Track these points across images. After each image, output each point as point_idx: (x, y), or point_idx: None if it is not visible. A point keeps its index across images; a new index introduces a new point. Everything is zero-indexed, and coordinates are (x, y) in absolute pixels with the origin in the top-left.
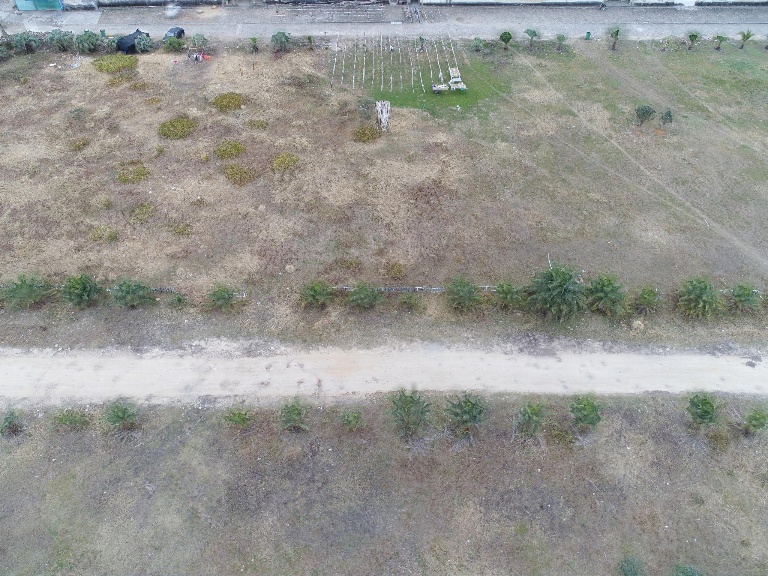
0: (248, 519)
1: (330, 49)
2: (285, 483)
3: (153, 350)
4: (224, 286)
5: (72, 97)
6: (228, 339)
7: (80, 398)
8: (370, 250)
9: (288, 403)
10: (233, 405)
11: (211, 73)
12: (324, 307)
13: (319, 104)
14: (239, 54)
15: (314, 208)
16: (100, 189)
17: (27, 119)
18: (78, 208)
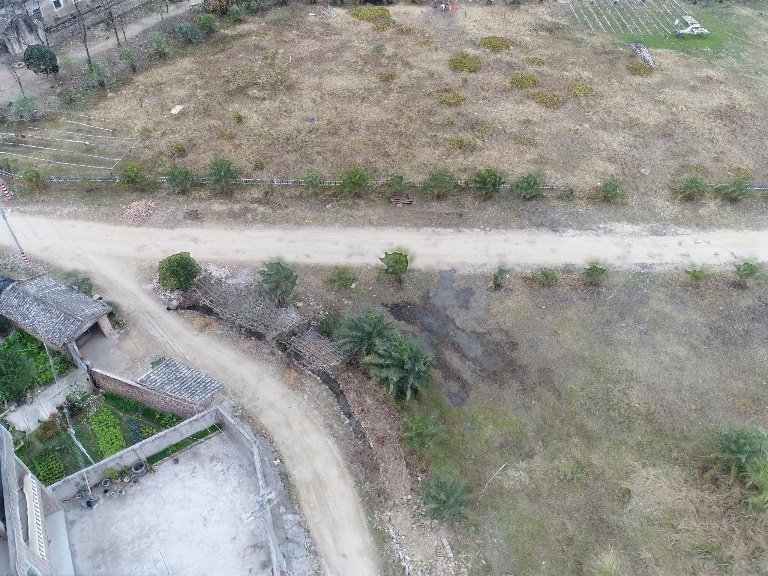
0: (743, 349)
1: (558, 2)
2: (757, 325)
3: (568, 231)
4: (596, 184)
5: (349, 40)
6: (629, 223)
7: (533, 264)
8: (707, 158)
9: (717, 269)
10: (669, 270)
11: (461, 21)
12: (697, 200)
13: (578, 46)
14: (476, 6)
15: (633, 126)
16: (432, 111)
17: (322, 57)
18: (422, 125)
